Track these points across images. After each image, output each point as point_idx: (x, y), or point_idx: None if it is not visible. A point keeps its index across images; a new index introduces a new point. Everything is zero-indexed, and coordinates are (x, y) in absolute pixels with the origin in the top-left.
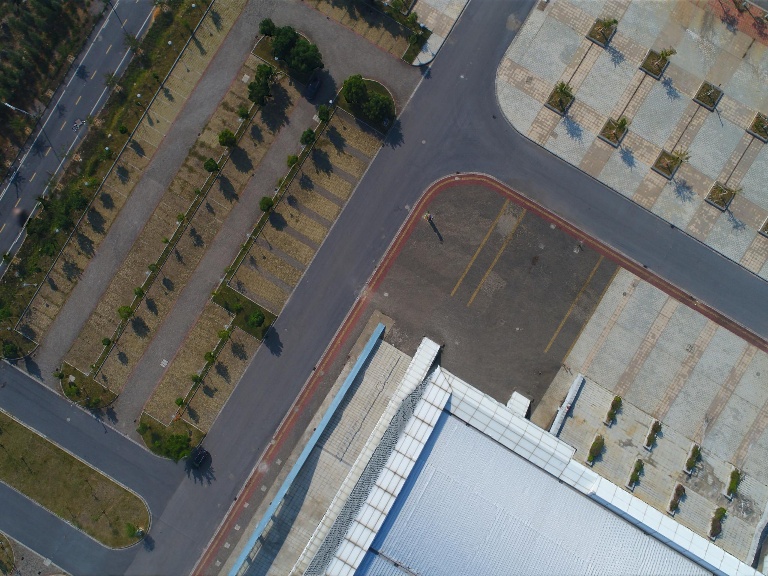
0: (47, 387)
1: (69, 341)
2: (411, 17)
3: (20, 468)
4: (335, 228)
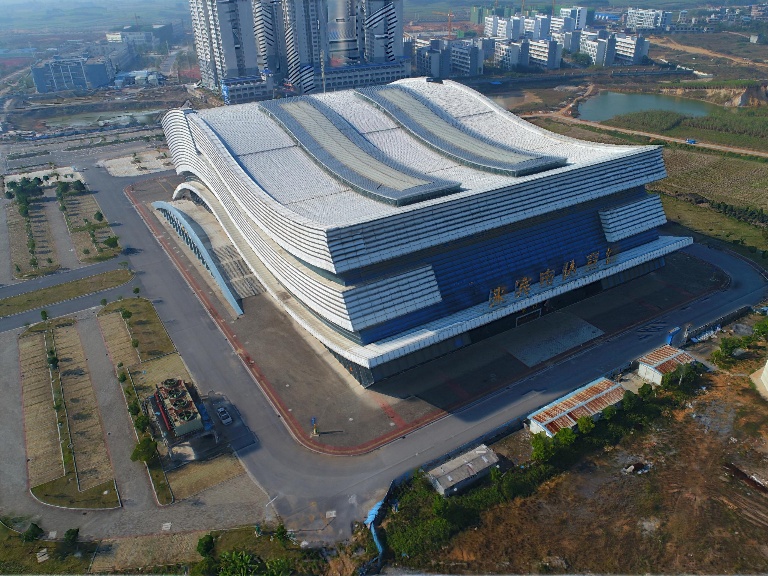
0: (13, 284)
1: (8, 272)
2: (64, 175)
3: (31, 303)
4: (100, 206)
